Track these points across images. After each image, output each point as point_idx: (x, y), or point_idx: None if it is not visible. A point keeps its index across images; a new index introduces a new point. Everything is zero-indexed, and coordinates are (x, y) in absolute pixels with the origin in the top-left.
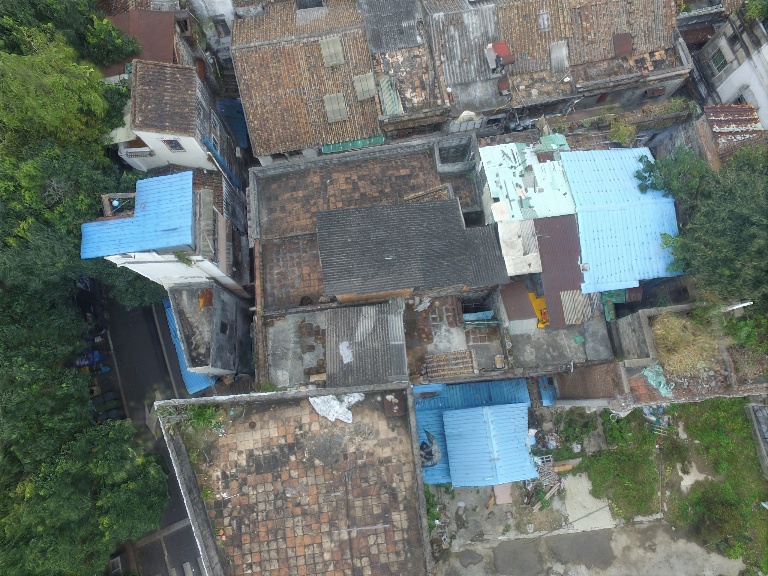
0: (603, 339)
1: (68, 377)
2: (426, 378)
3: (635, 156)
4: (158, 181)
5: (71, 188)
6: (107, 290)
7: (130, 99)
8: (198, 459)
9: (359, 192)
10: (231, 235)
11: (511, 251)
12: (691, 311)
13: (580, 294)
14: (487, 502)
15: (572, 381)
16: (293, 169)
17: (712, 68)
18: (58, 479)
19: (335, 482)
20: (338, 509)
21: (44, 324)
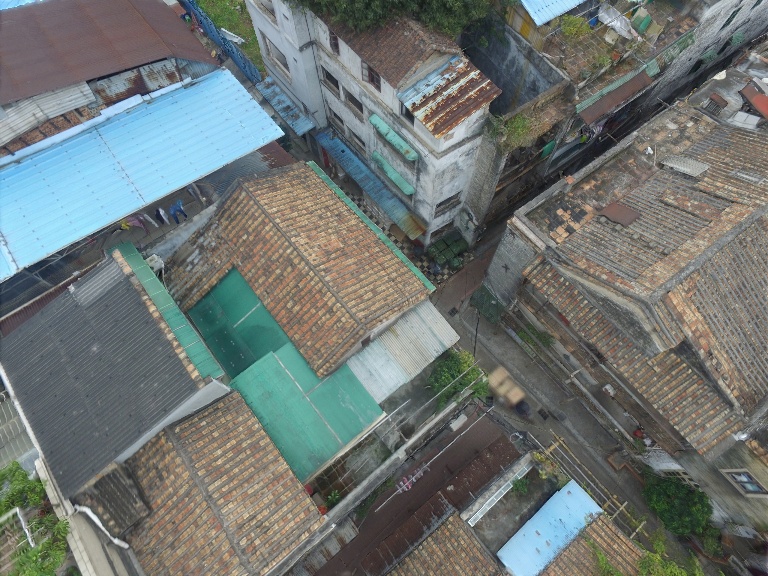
0: None
1: None
2: None
3: (548, 7)
4: None
5: None
6: None
7: None
8: None
9: None
10: None
11: None
12: None
13: None
14: None
15: None
16: None
17: None
18: None
19: None
20: None
21: None
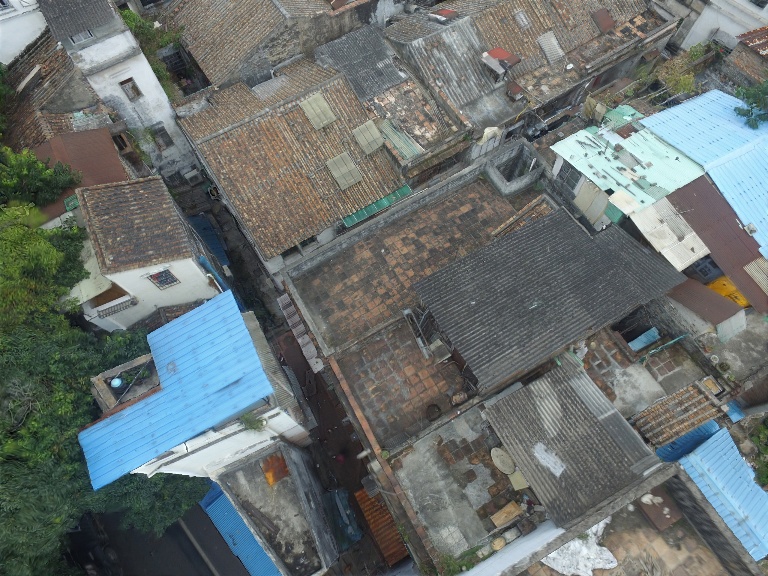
0: None
1: None
2: None
3: (712, 100)
4: (182, 323)
5: (43, 385)
6: (101, 518)
7: (86, 240)
8: None
9: (426, 250)
10: (280, 367)
11: (663, 242)
12: None
13: (764, 261)
14: None
15: (767, 376)
16: (333, 252)
17: None
18: None
19: None
20: None
21: None
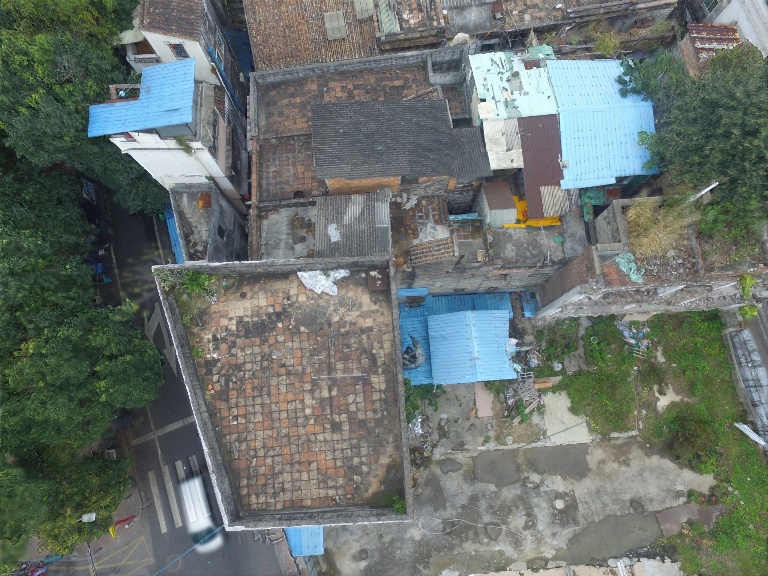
0: (581, 240)
1: (72, 263)
2: (410, 265)
3: (618, 66)
4: (163, 67)
5: (81, 73)
6: (112, 208)
7: (139, 4)
8: (191, 323)
9: (354, 100)
10: (231, 140)
11: (495, 147)
12: (663, 203)
13: (559, 189)
14: (469, 414)
15: (552, 287)
16: (292, 77)
17: (704, 9)
18: (60, 344)
19: (319, 347)
20: (320, 371)
21: (51, 215)
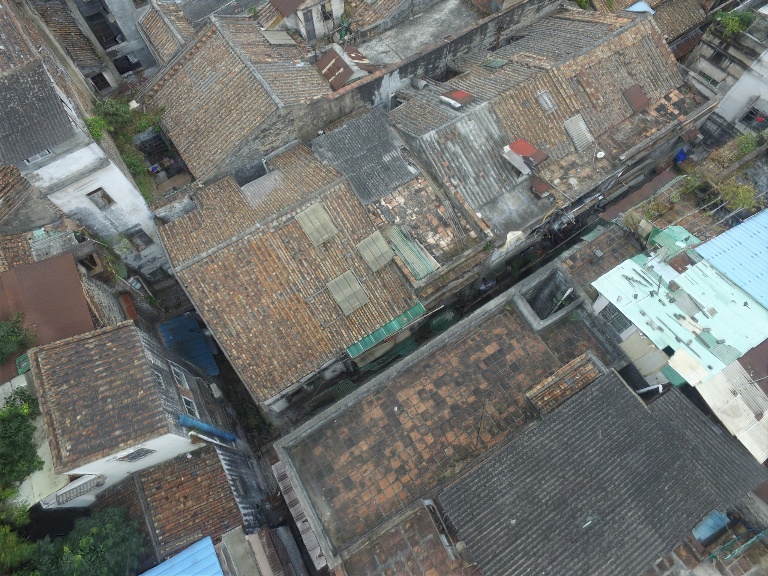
0: None
1: None
2: None
3: None
4: None
5: None
6: None
7: (40, 415)
8: None
9: (447, 406)
10: (276, 556)
11: (738, 421)
12: None
13: None
14: None
15: None
16: (337, 412)
17: None
18: None
19: None
20: None
21: None
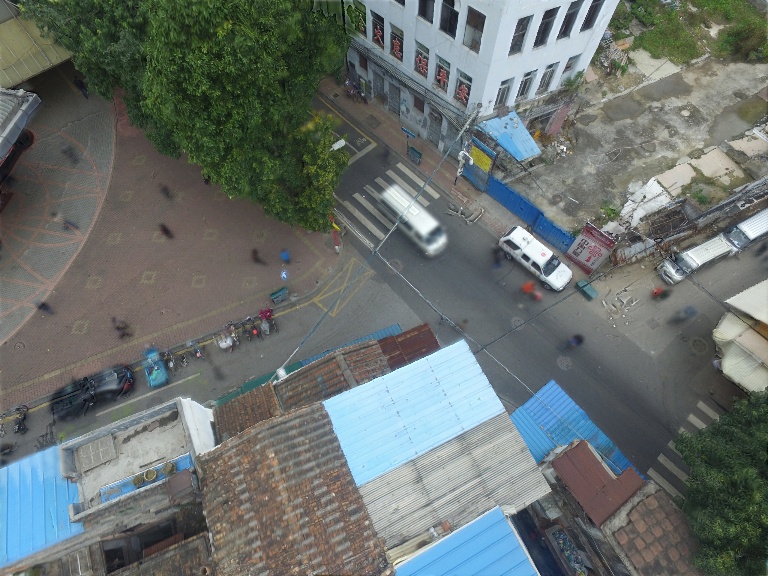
0: None
1: None
2: None
3: None
4: None
5: None
6: None
7: None
8: None
9: None
10: None
11: None
12: None
13: None
14: None
15: None
16: None
17: None
18: None
19: None
20: None
21: None
